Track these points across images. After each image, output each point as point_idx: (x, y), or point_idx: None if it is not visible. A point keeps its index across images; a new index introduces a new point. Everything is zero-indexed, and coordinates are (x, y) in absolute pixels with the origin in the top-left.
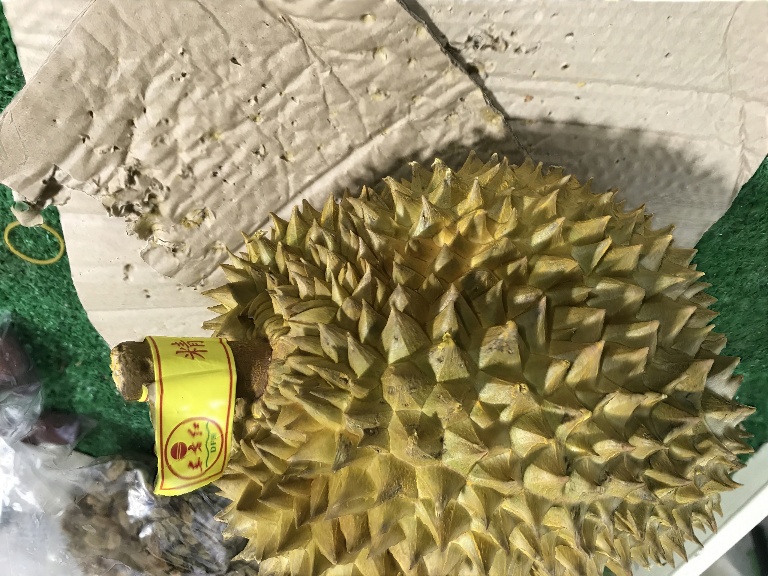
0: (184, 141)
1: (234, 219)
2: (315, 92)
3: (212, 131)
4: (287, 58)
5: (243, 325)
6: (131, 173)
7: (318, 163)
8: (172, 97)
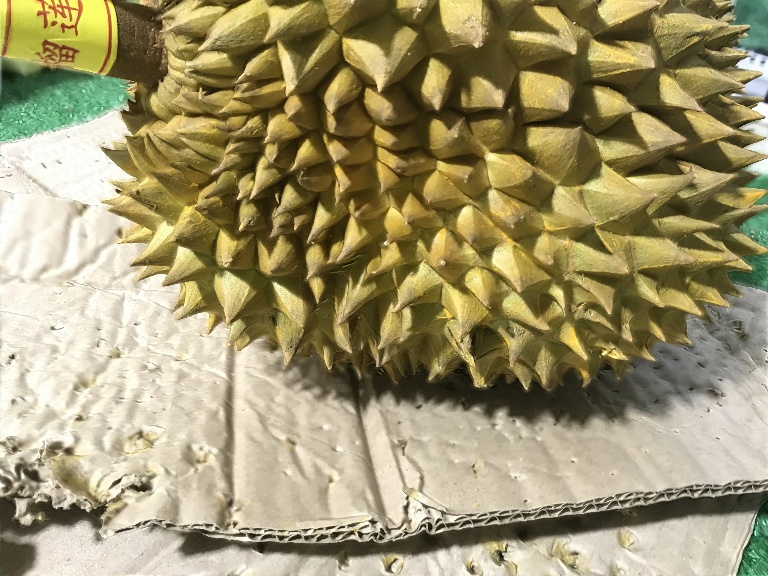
0: (57, 400)
1: (187, 419)
2: (148, 307)
3: (83, 382)
4: (99, 303)
5: (139, 118)
6: (9, 449)
7: (215, 342)
8: (12, 376)
